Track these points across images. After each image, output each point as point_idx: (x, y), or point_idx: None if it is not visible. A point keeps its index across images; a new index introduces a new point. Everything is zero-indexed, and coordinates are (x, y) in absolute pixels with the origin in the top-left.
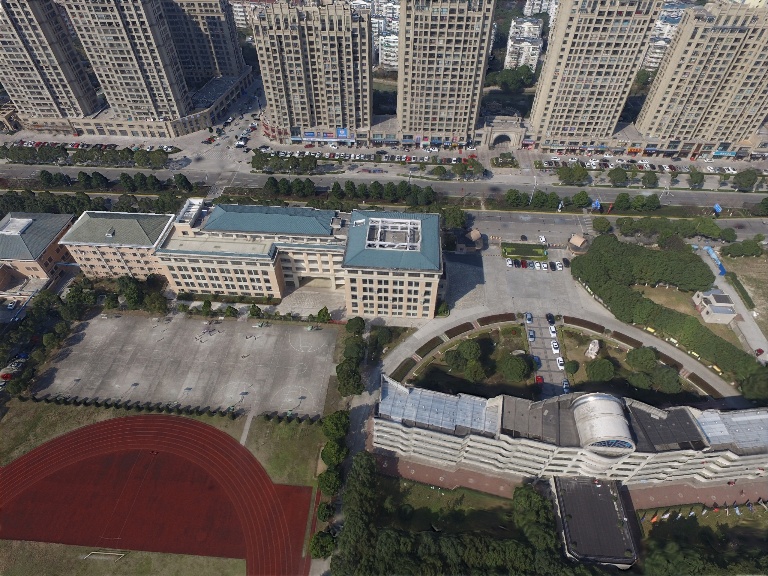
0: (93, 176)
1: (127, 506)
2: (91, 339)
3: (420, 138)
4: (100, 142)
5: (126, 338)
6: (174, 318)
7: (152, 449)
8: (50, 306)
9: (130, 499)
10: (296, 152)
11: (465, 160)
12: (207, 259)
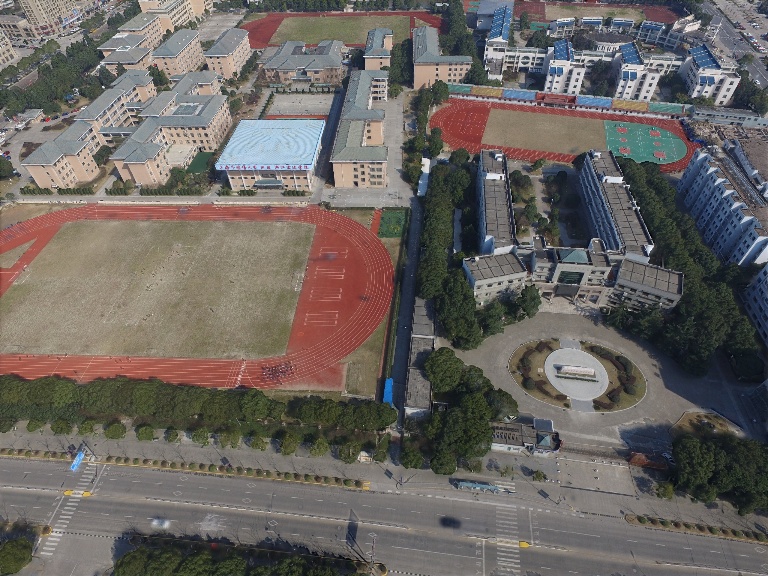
0: (61, 54)
1: None
2: None
3: (97, 2)
4: None
5: None
6: None
7: None
8: None
9: None
10: (76, 27)
11: (121, 1)
12: None
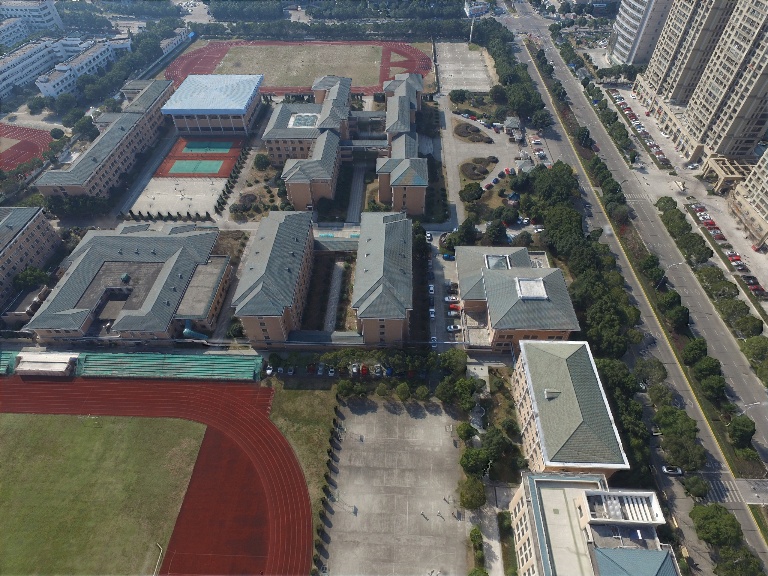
0: (677, 309)
1: (202, 568)
2: (418, 427)
3: None
4: (762, 278)
5: (423, 469)
6: (464, 522)
7: (266, 571)
8: (448, 367)
9: (209, 569)
10: None
11: None
12: (538, 572)
